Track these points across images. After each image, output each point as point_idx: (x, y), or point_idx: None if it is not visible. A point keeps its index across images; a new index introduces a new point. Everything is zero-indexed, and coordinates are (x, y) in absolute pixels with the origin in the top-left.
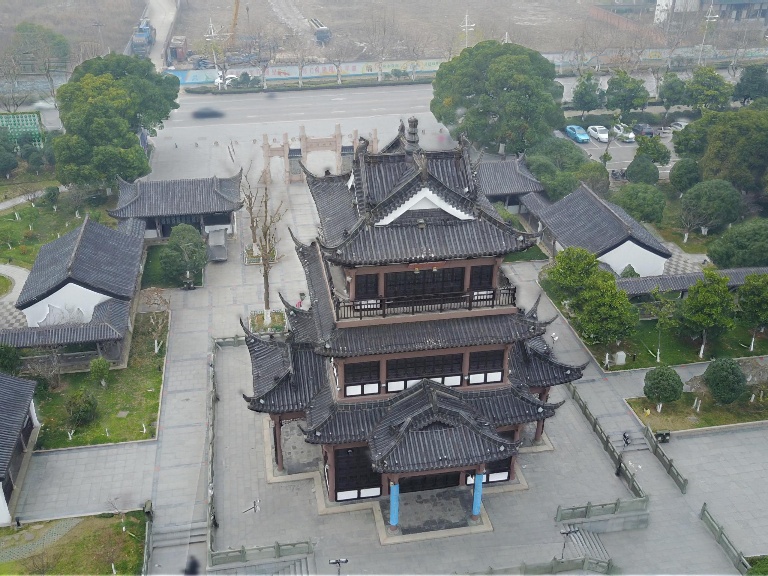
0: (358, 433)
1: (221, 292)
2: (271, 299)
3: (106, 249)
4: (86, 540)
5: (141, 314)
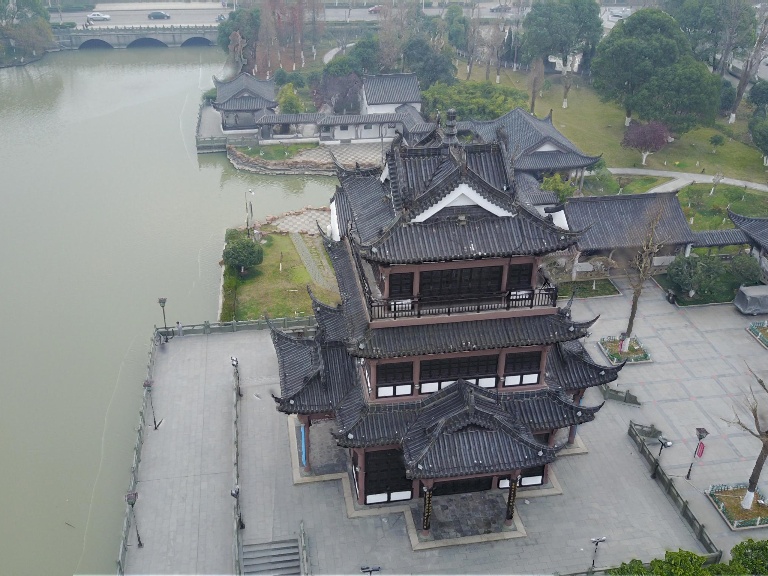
0: (328, 333)
1: (676, 319)
2: (679, 351)
3: (641, 218)
4: (326, 299)
5: (609, 281)
